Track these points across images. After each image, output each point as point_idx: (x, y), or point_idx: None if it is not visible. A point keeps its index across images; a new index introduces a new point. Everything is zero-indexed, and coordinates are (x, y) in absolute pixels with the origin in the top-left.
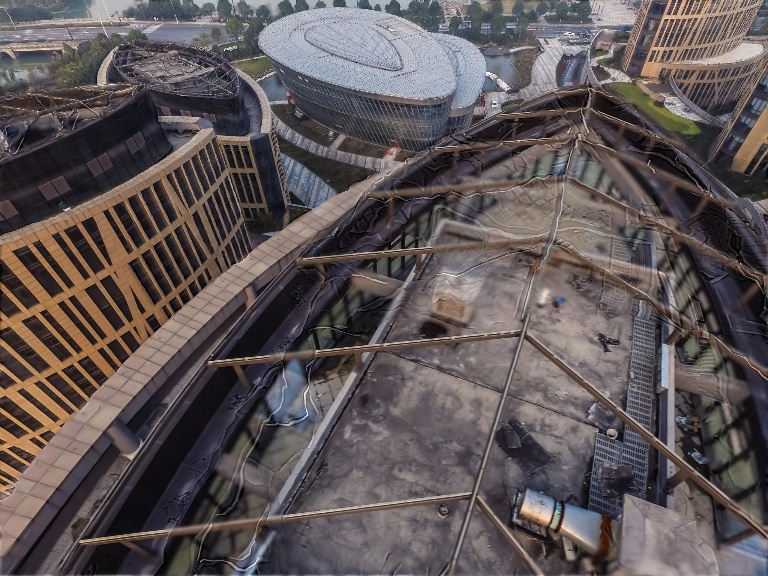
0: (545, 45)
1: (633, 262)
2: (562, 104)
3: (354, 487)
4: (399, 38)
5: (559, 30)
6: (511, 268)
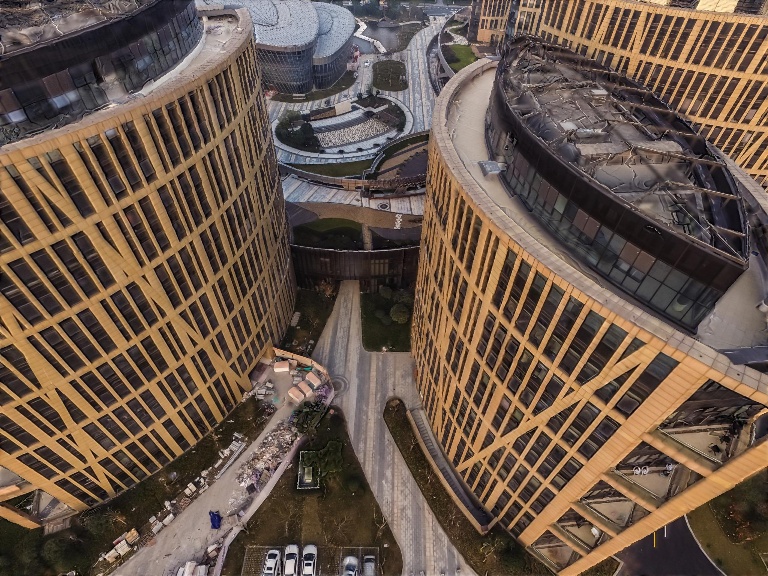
0: (432, 21)
1: (104, 1)
2: None
3: None
4: (283, 3)
5: (450, 10)
6: None
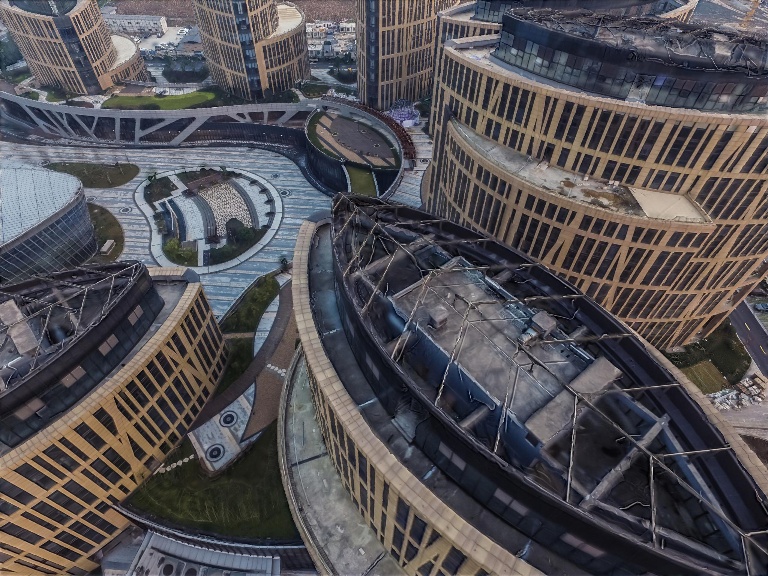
0: None
1: None
2: None
3: None
4: None
5: None
6: (620, 30)
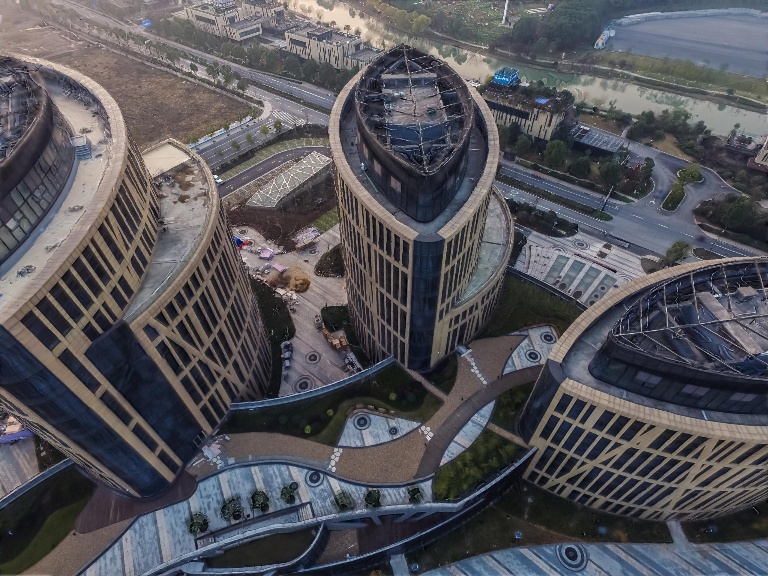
0: None
1: None
2: None
3: None
4: None
5: None
6: None
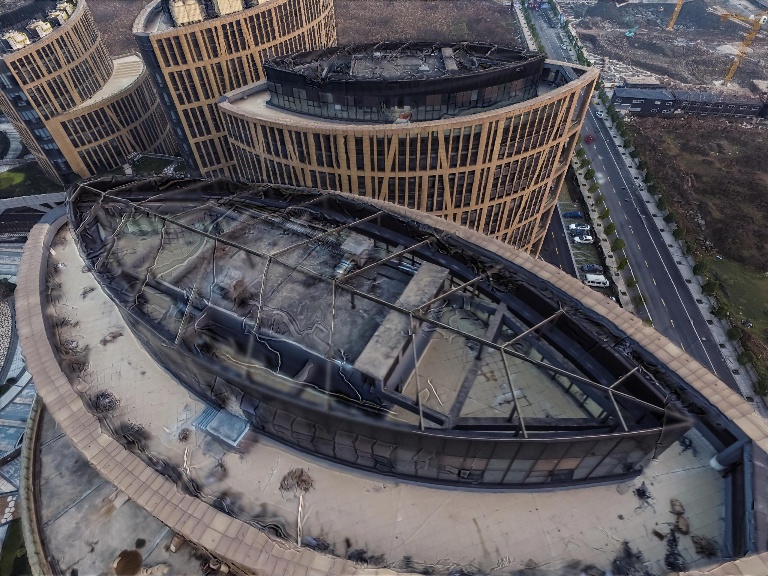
0: None
1: (244, 215)
2: (88, 201)
3: (326, 310)
4: None
5: None
6: (227, 255)
